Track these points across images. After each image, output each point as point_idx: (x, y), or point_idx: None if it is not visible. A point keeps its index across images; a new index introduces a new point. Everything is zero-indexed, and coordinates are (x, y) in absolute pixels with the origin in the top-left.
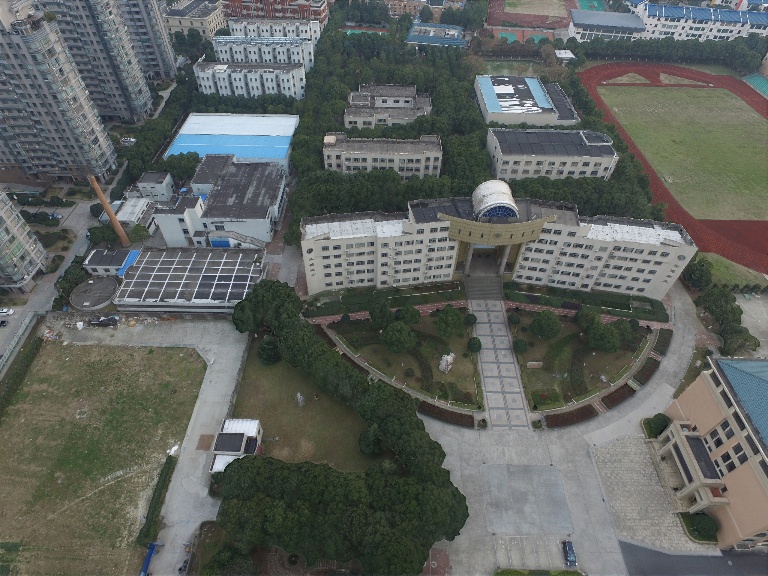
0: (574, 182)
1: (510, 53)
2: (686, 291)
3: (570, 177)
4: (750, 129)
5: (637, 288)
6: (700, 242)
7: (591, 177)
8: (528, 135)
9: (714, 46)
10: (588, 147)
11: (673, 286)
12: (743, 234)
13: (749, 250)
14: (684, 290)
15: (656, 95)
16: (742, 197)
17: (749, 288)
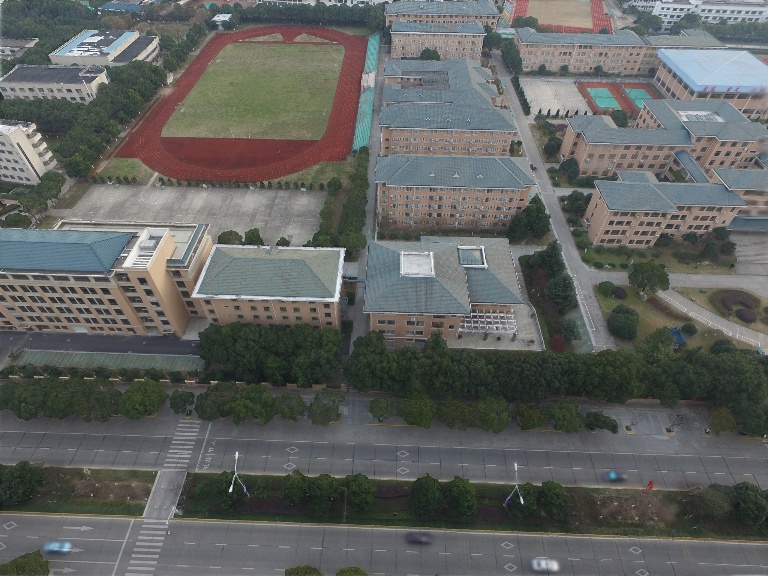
0: (38, 102)
1: (186, 18)
2: (74, 182)
3: (38, 99)
4: (314, 75)
5: (24, 178)
6: (138, 151)
7: (56, 99)
8: (46, 70)
9: (354, 10)
10: (81, 78)
11: (69, 179)
12: (183, 147)
13: (170, 157)
14: (74, 182)
15: (271, 50)
16: (225, 122)
17: (117, 179)
